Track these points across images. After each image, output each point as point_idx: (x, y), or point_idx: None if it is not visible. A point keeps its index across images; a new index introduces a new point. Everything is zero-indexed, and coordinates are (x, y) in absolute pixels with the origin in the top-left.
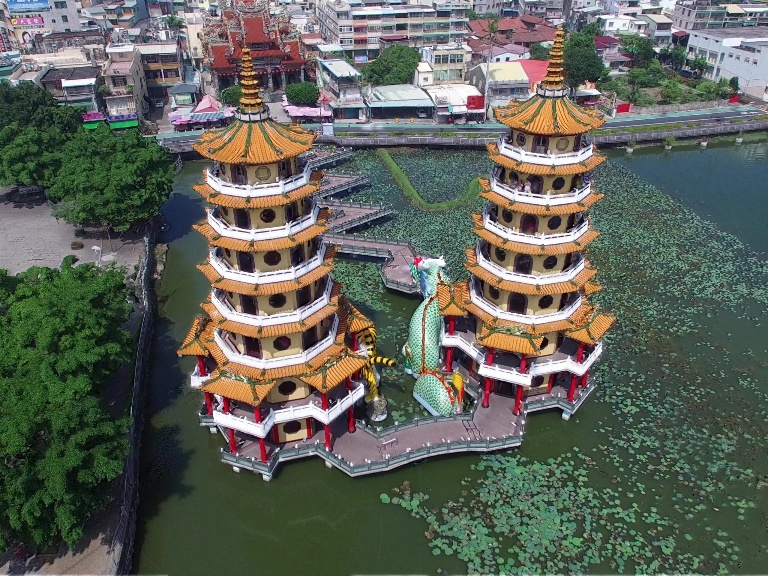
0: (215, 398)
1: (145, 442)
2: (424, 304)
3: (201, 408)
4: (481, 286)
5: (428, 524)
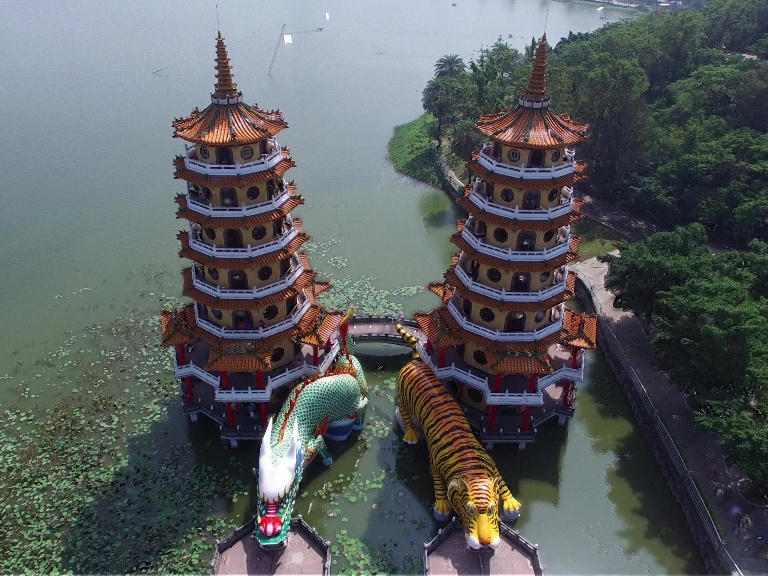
0: (569, 403)
1: (628, 408)
2: (336, 377)
3: (586, 430)
4: (290, 313)
5: (399, 316)
